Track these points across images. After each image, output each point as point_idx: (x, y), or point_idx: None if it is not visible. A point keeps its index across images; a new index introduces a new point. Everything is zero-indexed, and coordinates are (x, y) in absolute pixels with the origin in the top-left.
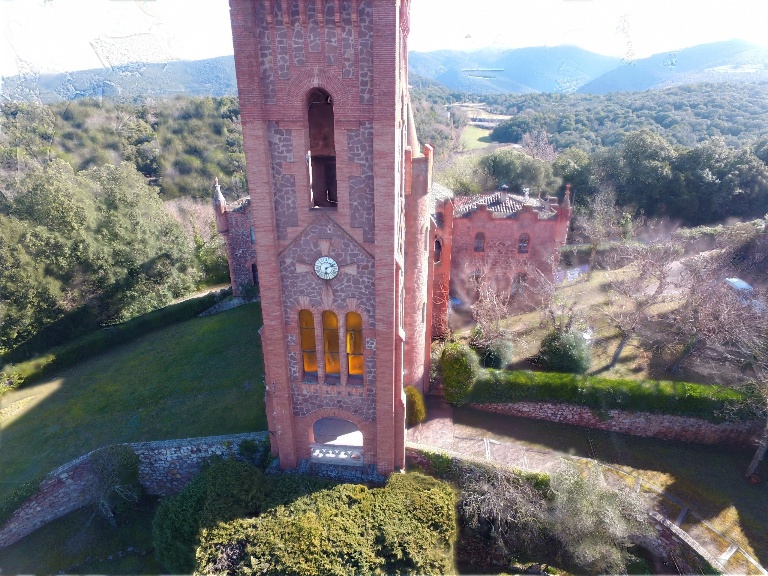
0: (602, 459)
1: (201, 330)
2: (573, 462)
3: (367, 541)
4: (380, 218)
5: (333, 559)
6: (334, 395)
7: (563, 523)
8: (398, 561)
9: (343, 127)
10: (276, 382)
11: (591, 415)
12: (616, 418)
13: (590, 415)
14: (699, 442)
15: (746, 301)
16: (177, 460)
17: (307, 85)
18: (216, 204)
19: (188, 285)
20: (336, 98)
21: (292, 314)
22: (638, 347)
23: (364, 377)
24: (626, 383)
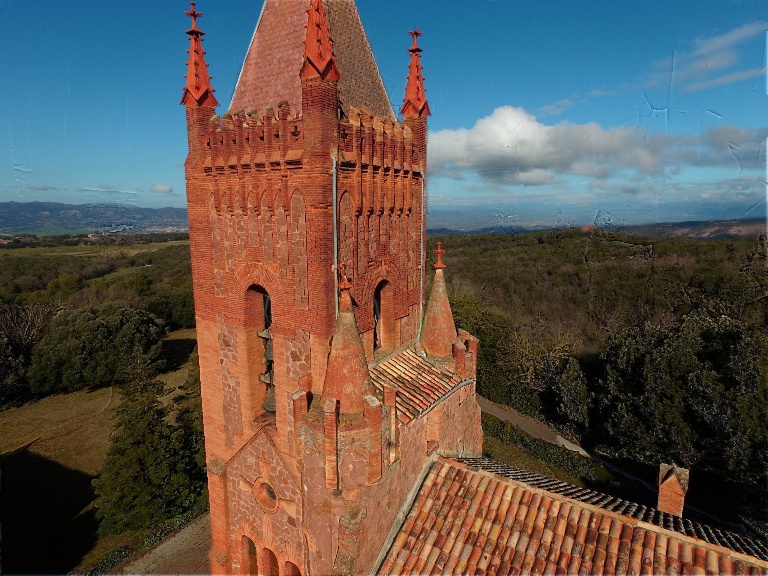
0: None
1: None
2: None
3: None
4: None
5: None
6: None
7: None
8: None
9: None
10: None
11: None
12: None
13: None
14: None
15: None
16: None
17: None
18: None
19: None
20: None
21: None
22: None
23: None
24: None
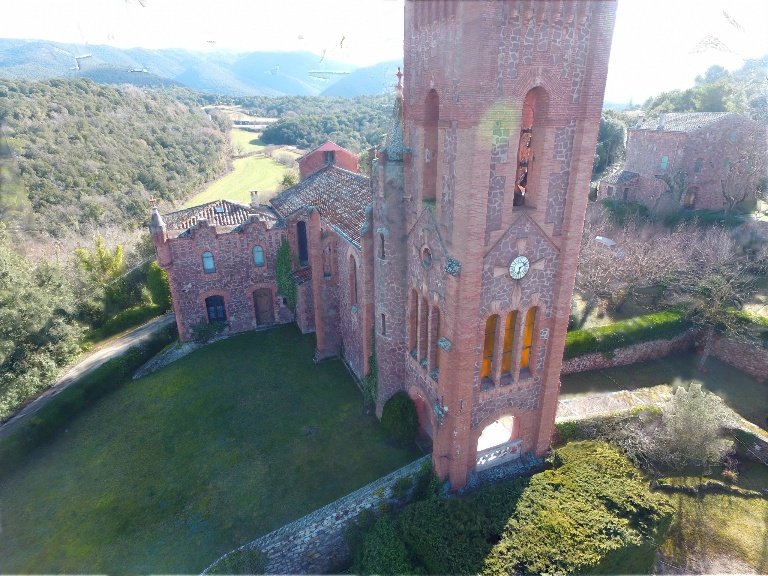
0: (629, 388)
1: (166, 392)
2: (618, 397)
3: (604, 511)
4: (575, 211)
5: (600, 538)
6: (506, 395)
7: (694, 435)
8: (633, 515)
9: (554, 126)
10: (463, 399)
11: (602, 358)
12: (617, 355)
13: (601, 358)
14: (659, 357)
15: (657, 248)
16: (317, 536)
17: (531, 84)
18: (156, 231)
19: (72, 347)
20: (552, 97)
21: (482, 322)
22: (583, 300)
23: (534, 368)
24: (619, 326)
